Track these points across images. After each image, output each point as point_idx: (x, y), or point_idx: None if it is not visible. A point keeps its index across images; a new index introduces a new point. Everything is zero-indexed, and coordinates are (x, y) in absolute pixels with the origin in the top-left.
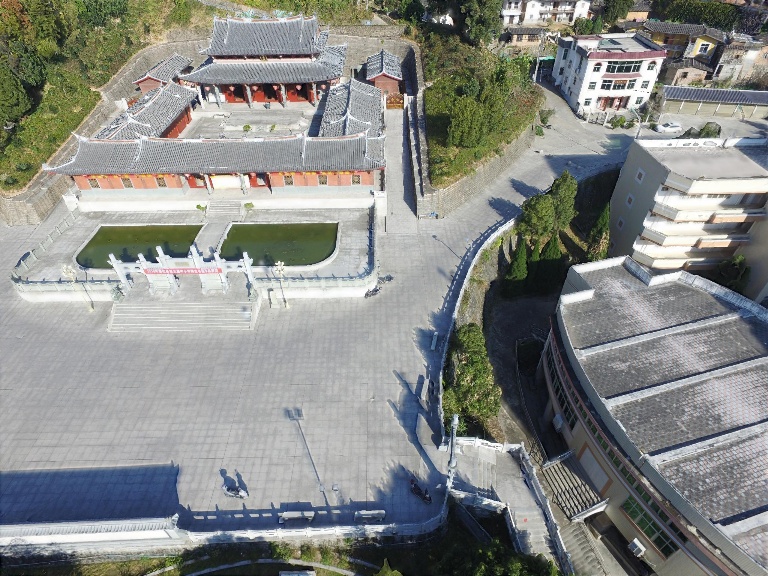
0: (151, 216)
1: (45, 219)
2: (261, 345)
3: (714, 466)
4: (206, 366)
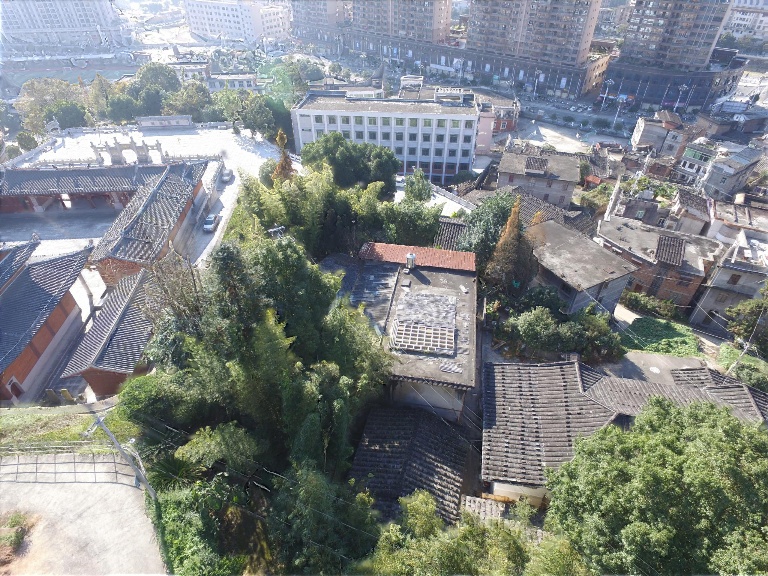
0: None
1: None
2: None
3: None
4: None
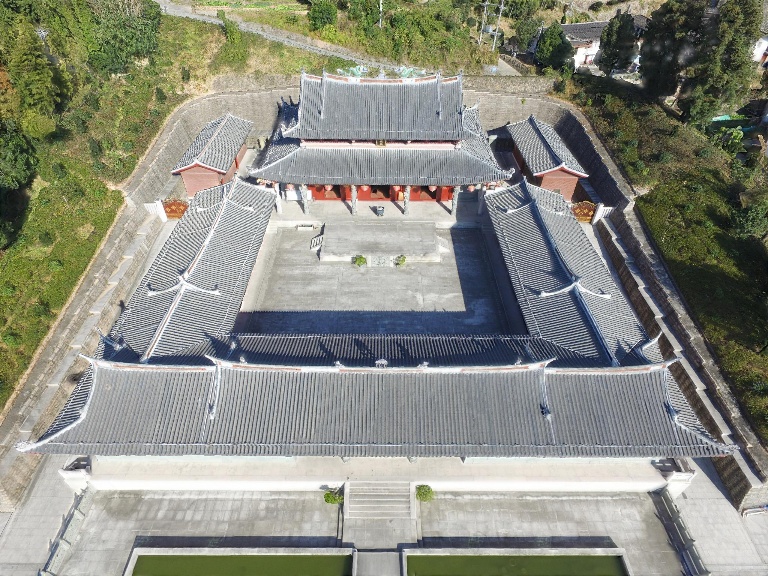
0: (233, 511)
1: (25, 496)
2: None
3: None
4: None
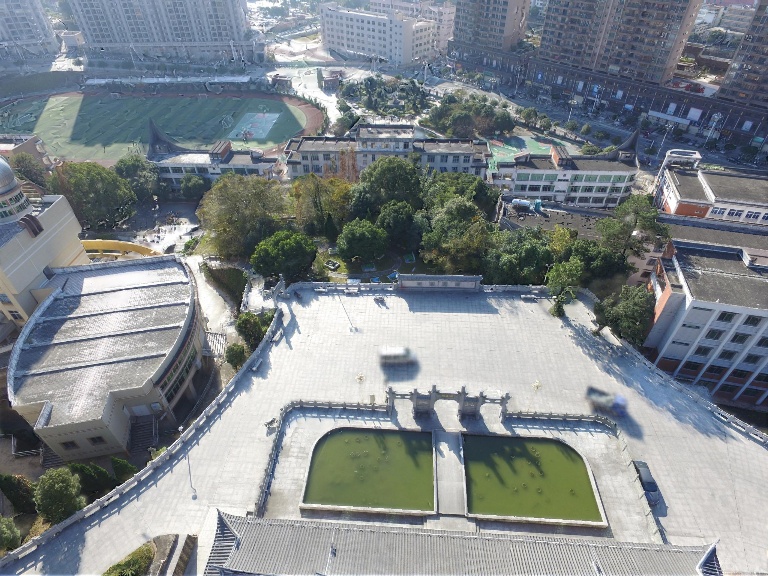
0: None
1: None
2: (379, 372)
3: (160, 299)
4: (414, 359)
